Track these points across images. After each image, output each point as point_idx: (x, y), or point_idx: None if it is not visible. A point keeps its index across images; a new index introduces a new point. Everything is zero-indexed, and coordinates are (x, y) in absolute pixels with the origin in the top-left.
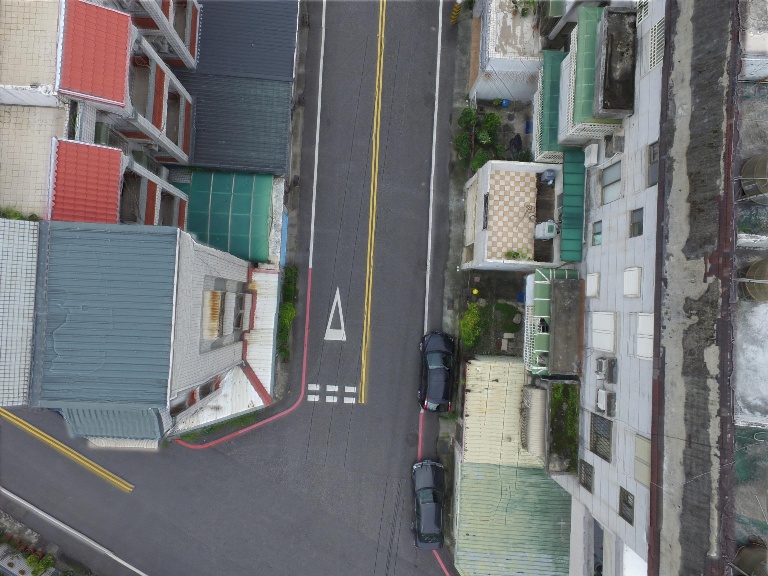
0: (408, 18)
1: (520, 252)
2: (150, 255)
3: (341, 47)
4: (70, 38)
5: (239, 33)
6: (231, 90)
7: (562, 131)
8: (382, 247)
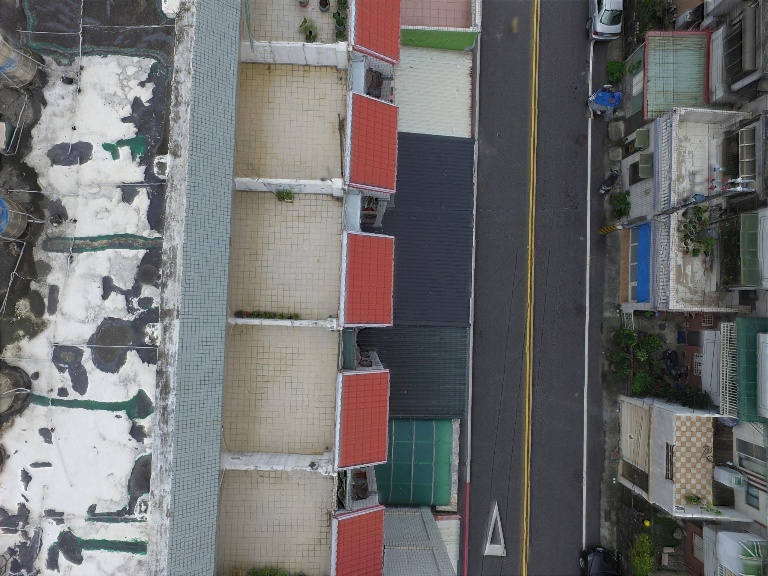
0: (557, 229)
1: (699, 493)
2: None
3: (491, 259)
4: (345, 414)
5: (417, 281)
6: (411, 339)
7: (765, 408)
8: (538, 460)
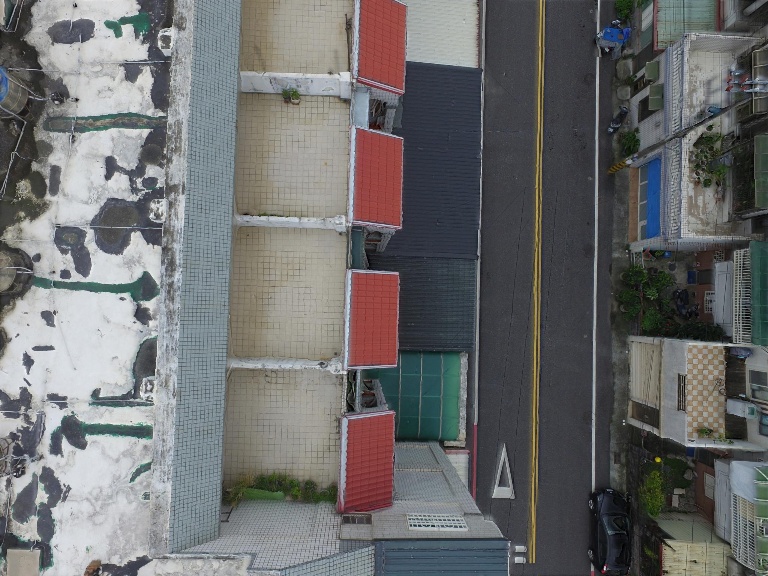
0: (565, 169)
1: (711, 426)
2: (484, 571)
3: (498, 199)
4: (355, 312)
5: (424, 212)
6: (418, 271)
7: None
8: (547, 402)
